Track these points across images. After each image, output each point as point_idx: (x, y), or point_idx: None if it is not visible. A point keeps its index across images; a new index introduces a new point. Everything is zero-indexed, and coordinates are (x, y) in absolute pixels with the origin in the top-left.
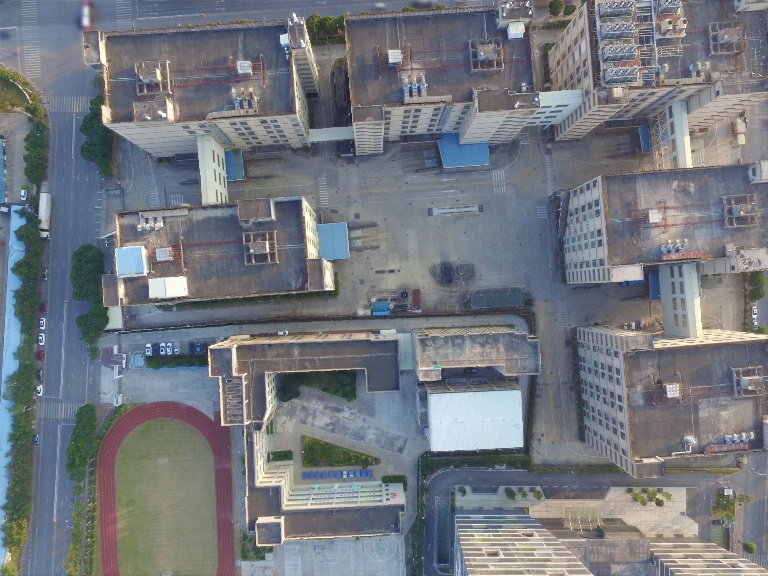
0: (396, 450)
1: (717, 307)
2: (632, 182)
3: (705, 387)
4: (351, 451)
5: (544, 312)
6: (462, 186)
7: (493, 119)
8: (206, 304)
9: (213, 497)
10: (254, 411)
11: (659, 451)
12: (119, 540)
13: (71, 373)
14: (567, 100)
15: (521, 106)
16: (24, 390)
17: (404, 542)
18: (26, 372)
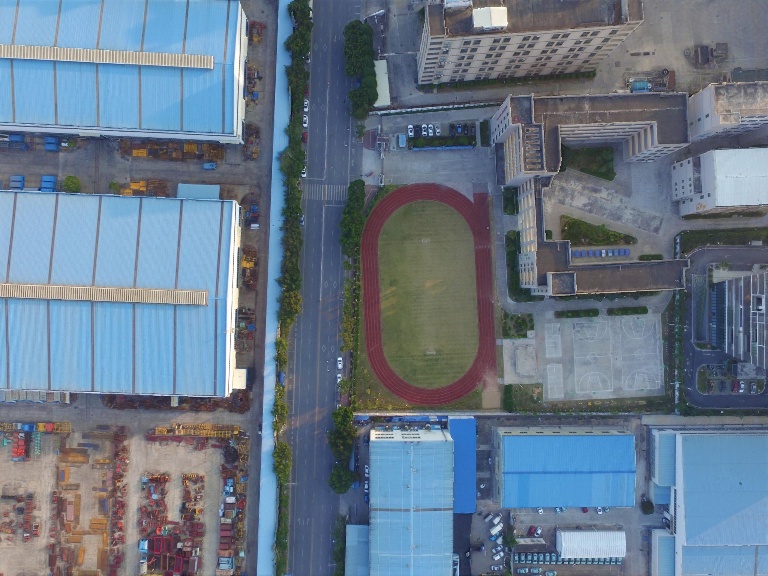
0: (652, 230)
1: None
2: None
3: None
4: (609, 230)
5: None
6: None
7: None
8: (467, 85)
9: (473, 277)
10: (547, 164)
11: None
12: (382, 320)
13: (334, 155)
14: None
15: None
16: (299, 163)
17: (661, 320)
18: (297, 147)
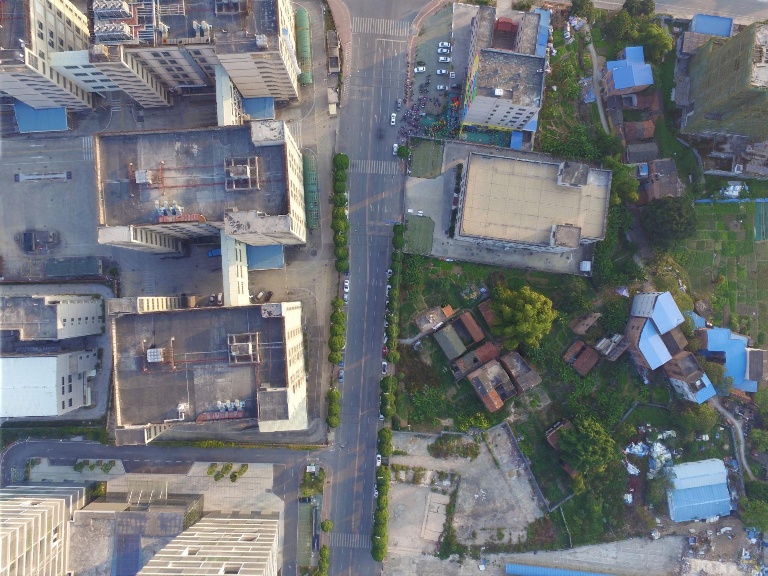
0: None
1: (310, 280)
2: (133, 142)
3: (201, 353)
4: None
5: (131, 282)
6: (50, 152)
7: (0, 77)
8: None
9: None
10: None
11: (152, 418)
12: None
13: None
14: (88, 60)
15: (6, 62)
16: None
17: None
18: None
